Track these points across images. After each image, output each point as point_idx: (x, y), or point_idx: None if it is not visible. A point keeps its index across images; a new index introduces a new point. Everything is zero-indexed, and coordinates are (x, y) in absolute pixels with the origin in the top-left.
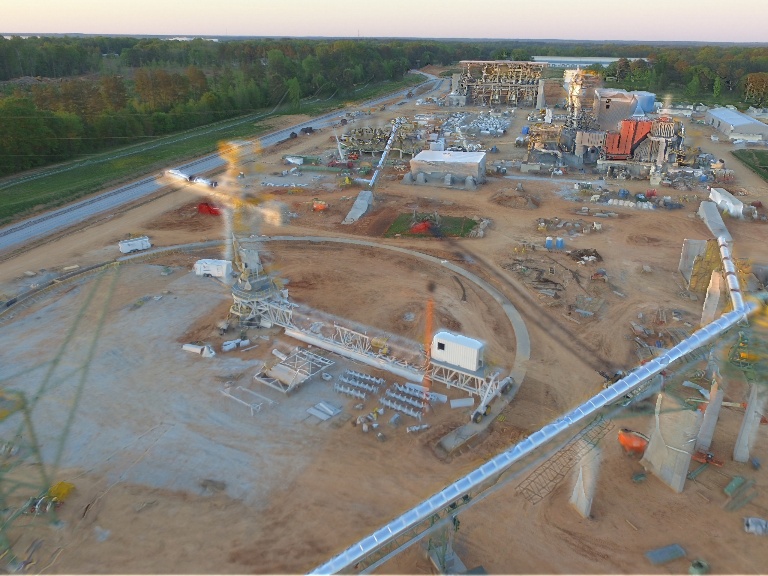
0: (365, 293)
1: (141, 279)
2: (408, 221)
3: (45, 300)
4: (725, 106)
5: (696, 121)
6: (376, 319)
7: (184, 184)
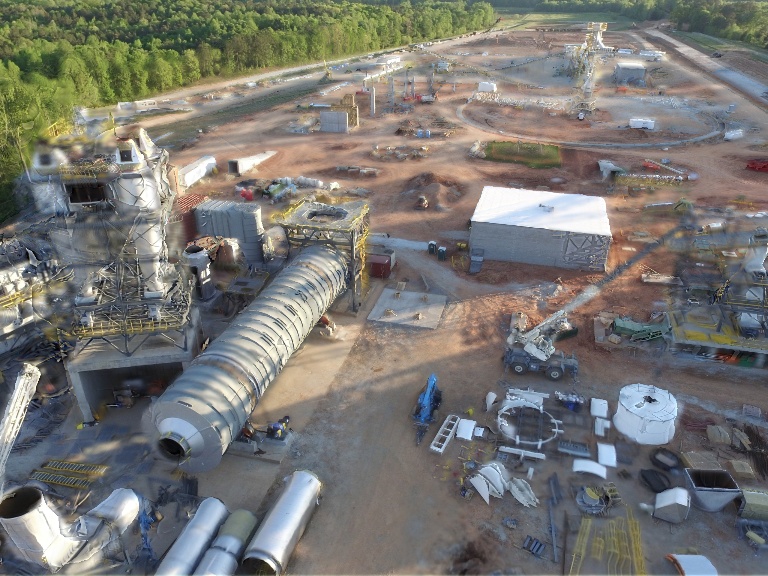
0: None
1: (681, 127)
2: None
3: None
4: None
5: None
6: None
7: None
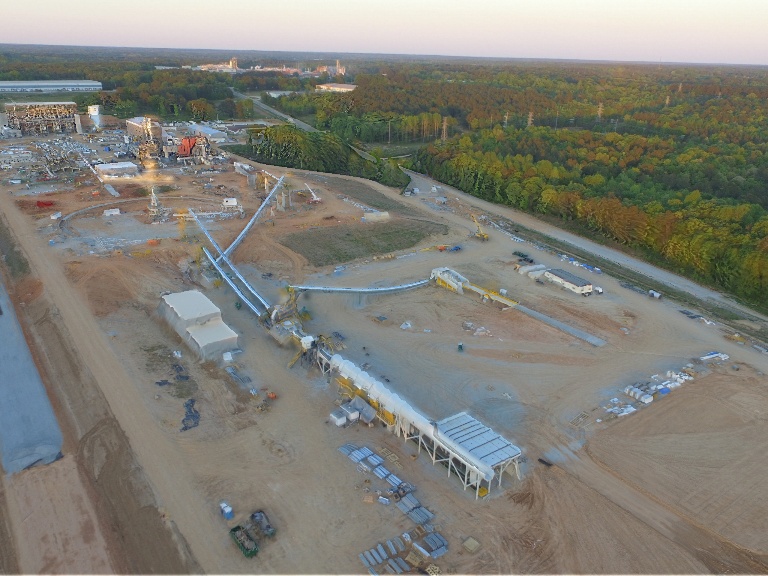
0: None
1: None
2: (146, 190)
3: None
4: (188, 122)
5: (185, 133)
6: None
7: None
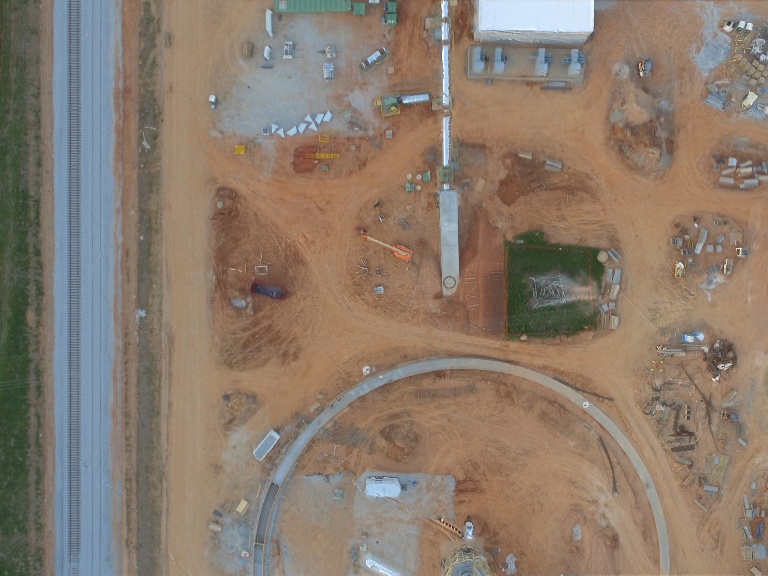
0: (530, 493)
1: (323, 513)
2: (526, 292)
3: (274, 574)
4: None
5: None
6: (552, 540)
7: (136, 140)
